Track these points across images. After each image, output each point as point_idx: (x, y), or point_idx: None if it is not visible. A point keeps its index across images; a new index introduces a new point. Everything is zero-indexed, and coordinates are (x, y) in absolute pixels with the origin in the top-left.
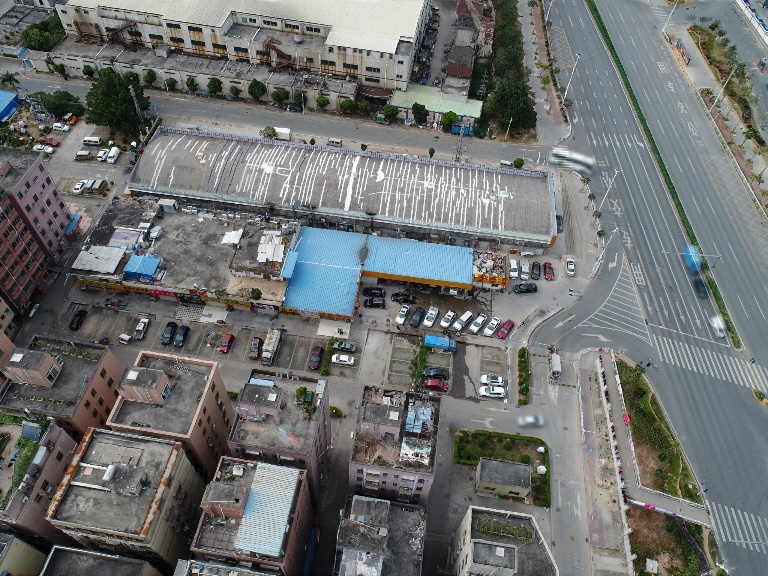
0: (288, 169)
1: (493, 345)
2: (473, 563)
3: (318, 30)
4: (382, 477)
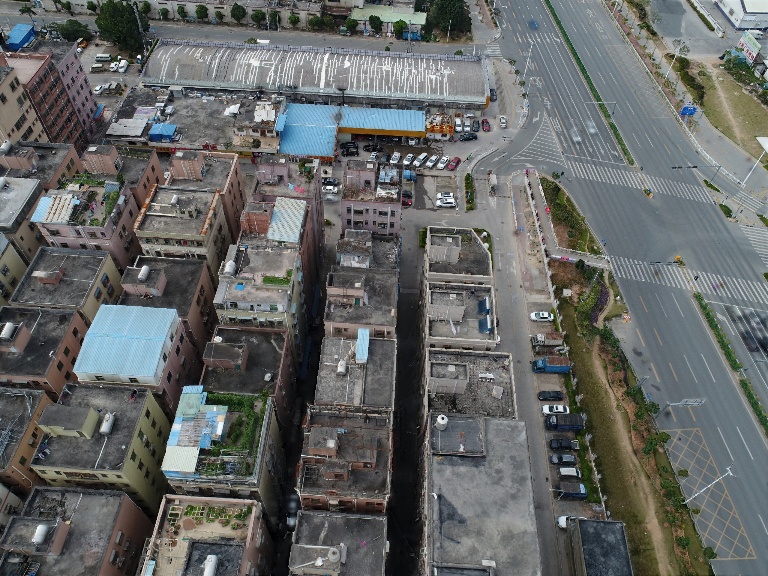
0: (271, 63)
1: (445, 175)
2: (431, 245)
3: None
4: (365, 215)
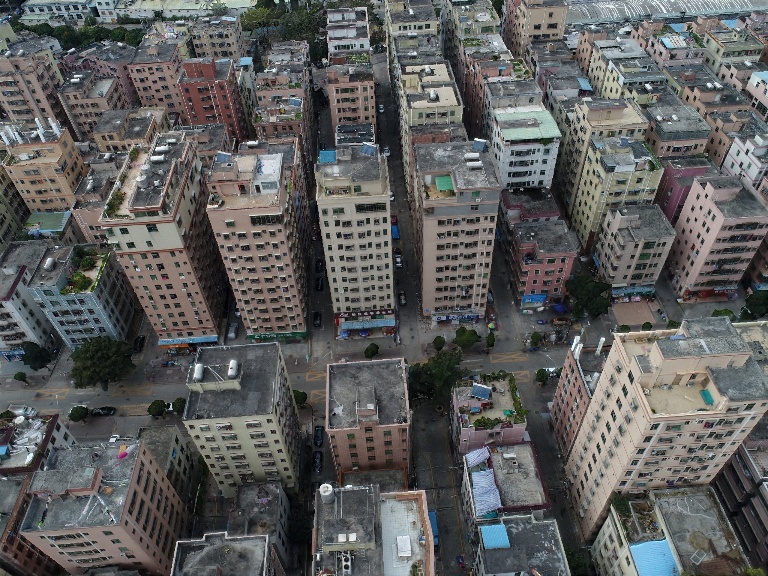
0: (622, 5)
1: None
2: None
3: None
4: None
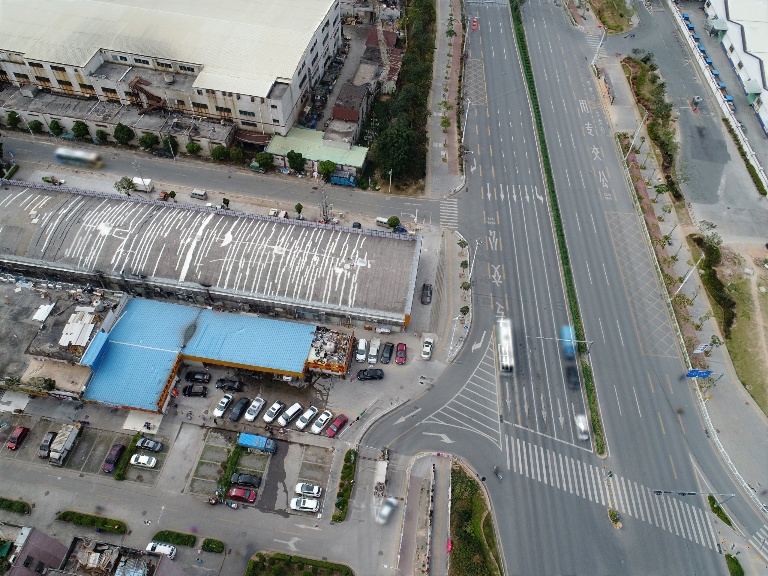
0: (126, 231)
1: (319, 445)
2: None
3: (192, 69)
4: None
